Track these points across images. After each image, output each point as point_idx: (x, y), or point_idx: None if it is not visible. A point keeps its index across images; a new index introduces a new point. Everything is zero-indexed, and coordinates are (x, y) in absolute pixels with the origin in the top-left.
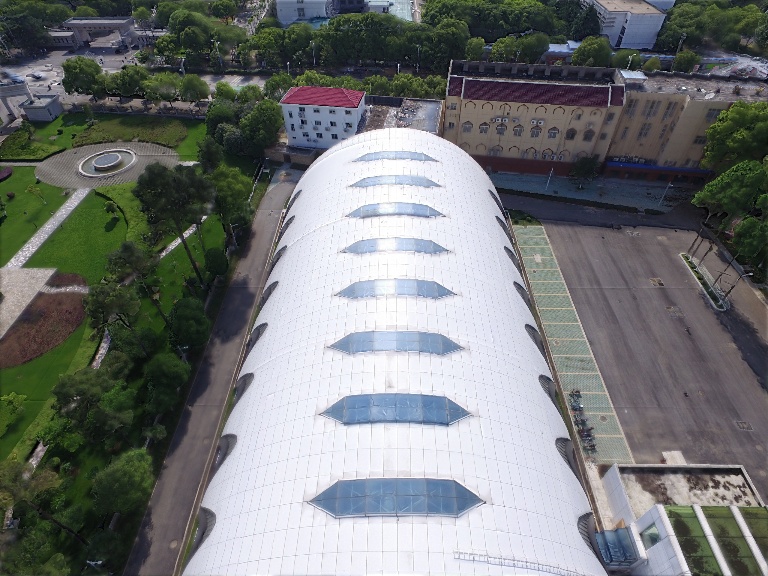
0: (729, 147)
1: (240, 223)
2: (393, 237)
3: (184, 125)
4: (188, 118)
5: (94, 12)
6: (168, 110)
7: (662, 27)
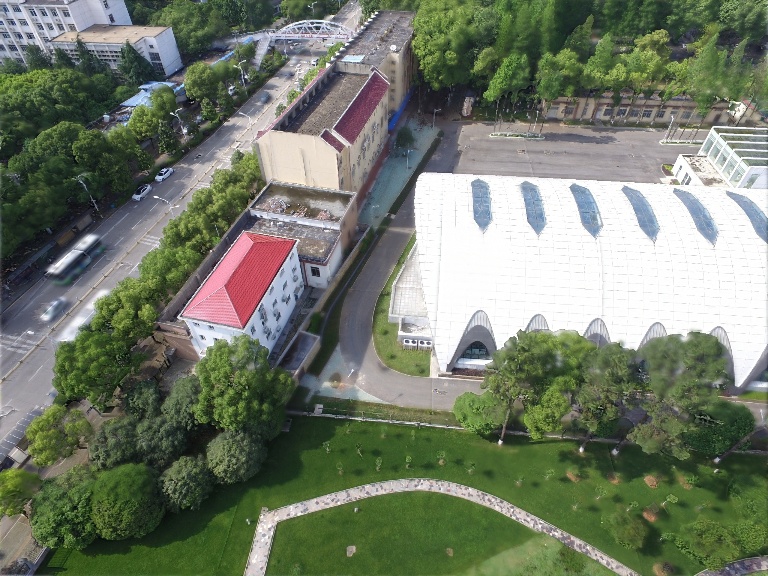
0: None
1: None
2: (632, 206)
3: None
4: None
5: None
6: None
7: (176, 39)
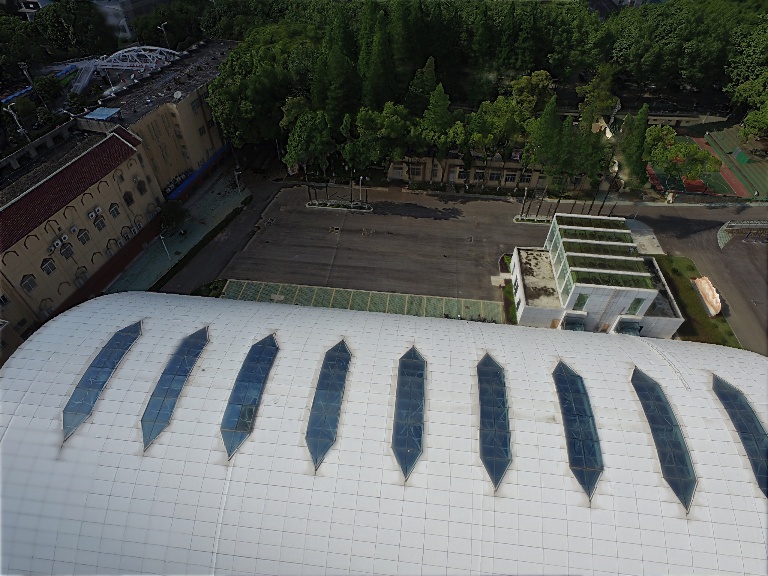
0: None
1: None
2: (315, 391)
3: None
4: None
5: None
6: None
7: None
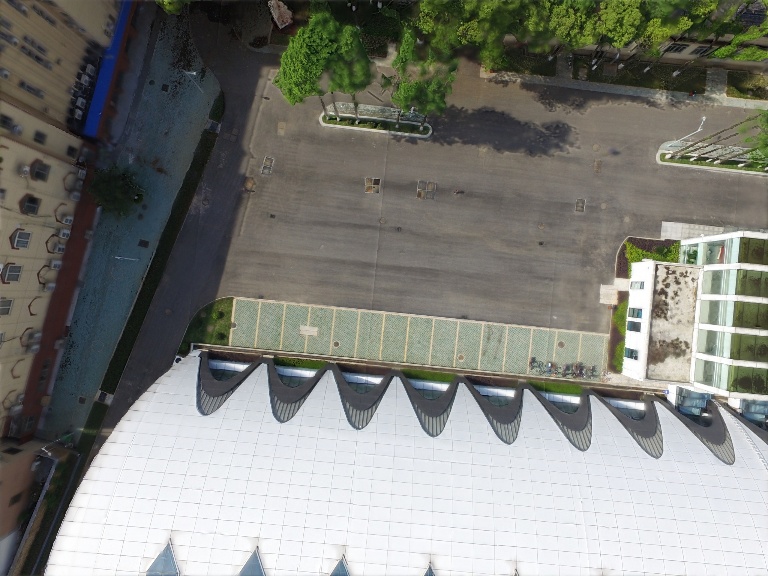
0: None
1: None
2: None
3: None
4: None
5: None
6: None
7: None
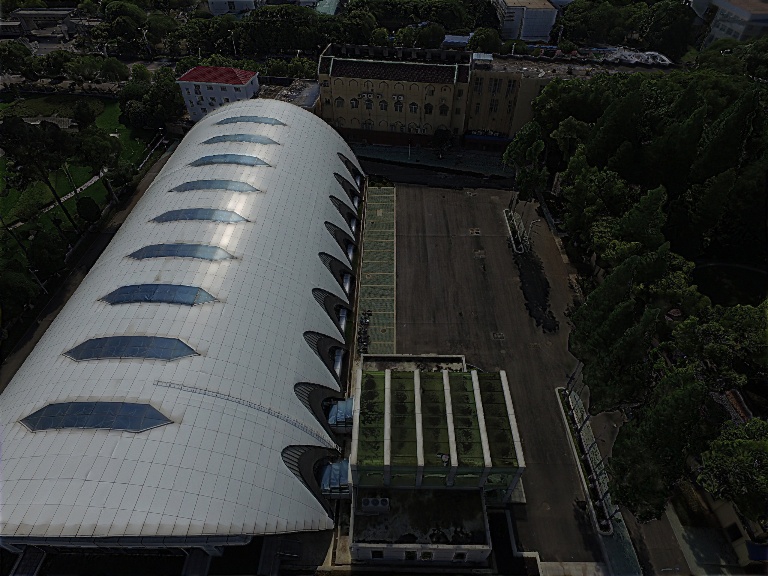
0: (542, 116)
1: (120, 180)
2: (214, 179)
3: (102, 103)
4: (108, 97)
5: (43, 4)
6: (92, 90)
7: (555, 21)
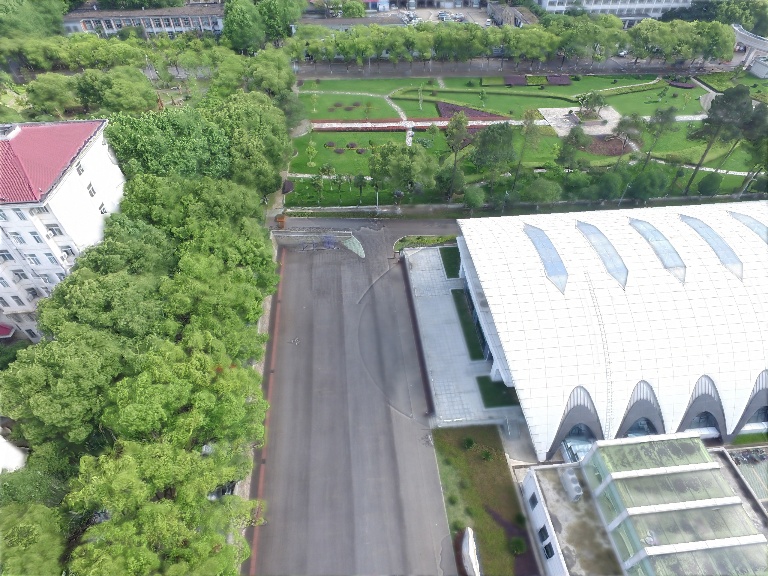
0: None
1: (762, 186)
2: None
3: None
4: None
5: None
6: None
7: None
